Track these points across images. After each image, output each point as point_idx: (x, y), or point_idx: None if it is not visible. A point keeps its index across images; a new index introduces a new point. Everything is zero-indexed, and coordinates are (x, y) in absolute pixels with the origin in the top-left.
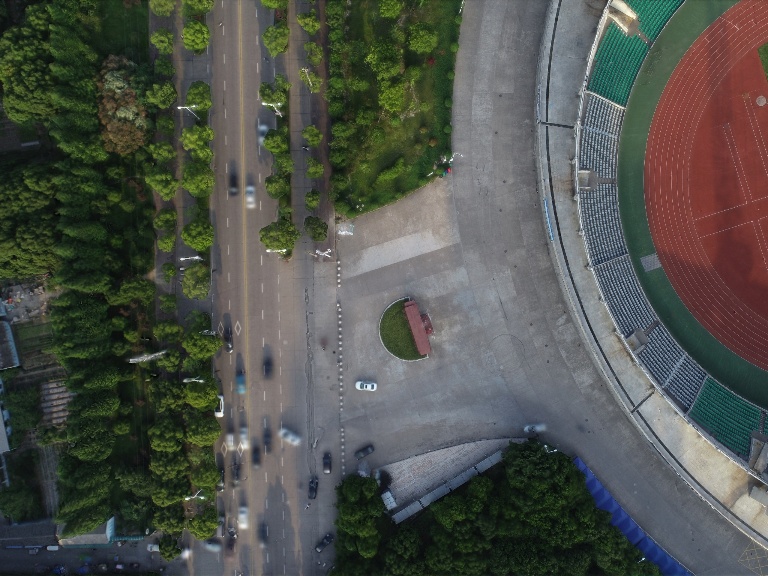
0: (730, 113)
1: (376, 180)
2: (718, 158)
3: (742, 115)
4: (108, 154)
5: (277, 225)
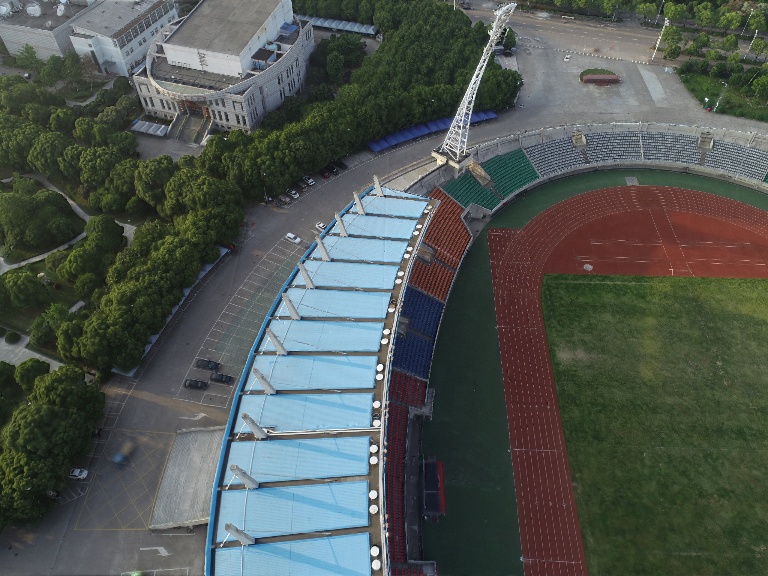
0: (761, 250)
1: (702, 83)
2: (719, 234)
3: (760, 257)
4: (720, 5)
5: (679, 31)
